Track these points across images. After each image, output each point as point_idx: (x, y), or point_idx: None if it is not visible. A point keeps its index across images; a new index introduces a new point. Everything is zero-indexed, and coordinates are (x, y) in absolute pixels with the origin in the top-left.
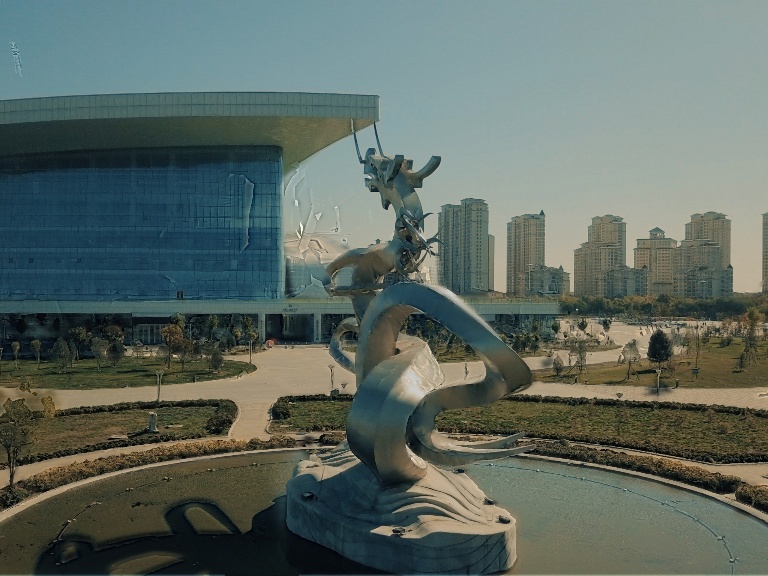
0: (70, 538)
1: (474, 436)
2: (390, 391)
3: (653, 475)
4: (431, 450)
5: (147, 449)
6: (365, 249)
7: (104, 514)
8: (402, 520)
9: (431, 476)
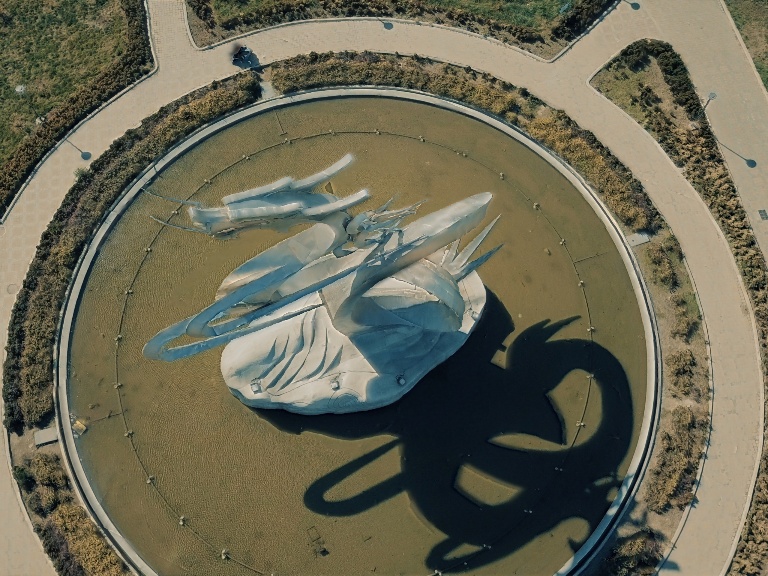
0: (423, 570)
1: None
2: (455, 289)
3: (205, 128)
4: None
5: None
6: (279, 272)
7: (351, 572)
8: None
9: None
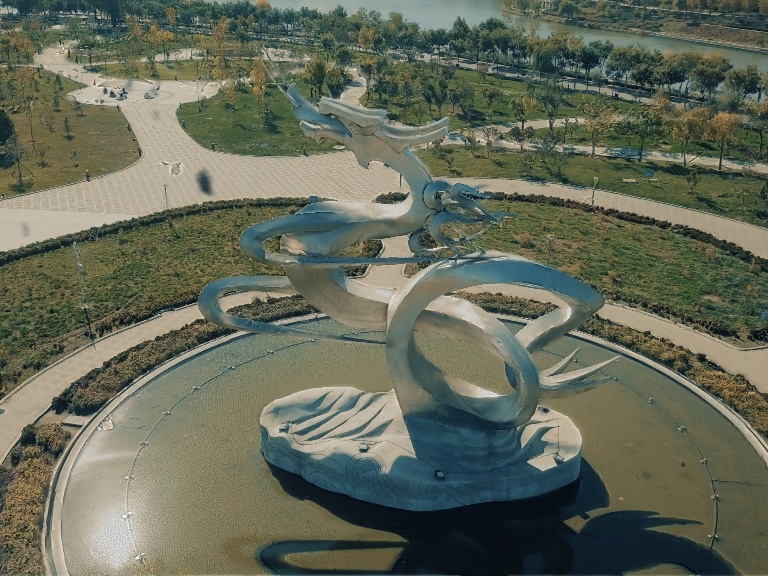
0: None
1: (151, 323)
2: None
3: None
4: (552, 390)
5: None
6: (347, 215)
7: None
8: (530, 449)
9: None
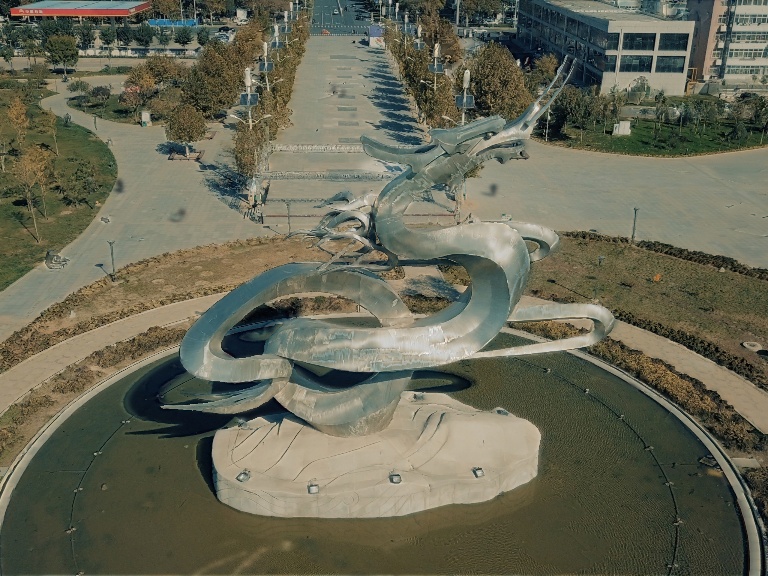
0: None
1: None
2: None
3: None
4: None
5: (687, 360)
6: None
7: None
8: None
9: (334, 440)
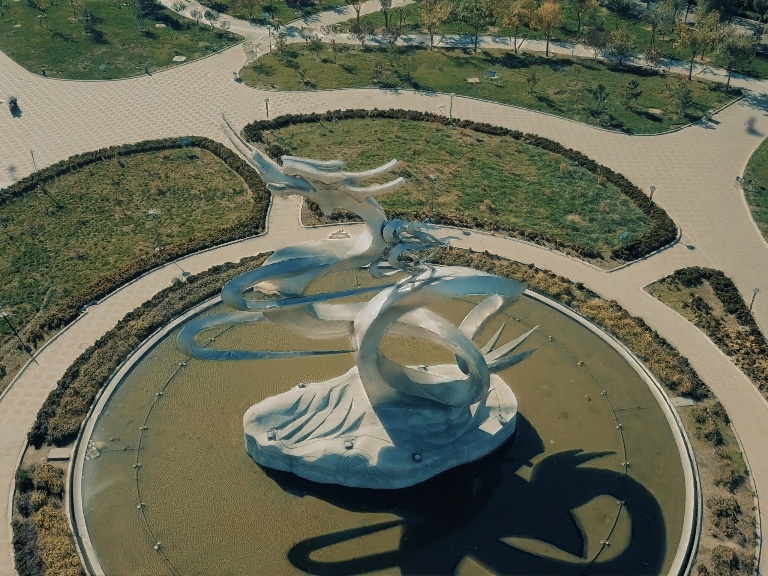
0: None
1: (81, 324)
2: (481, 355)
3: None
4: None
5: None
6: (317, 258)
7: None
8: (479, 416)
9: None
